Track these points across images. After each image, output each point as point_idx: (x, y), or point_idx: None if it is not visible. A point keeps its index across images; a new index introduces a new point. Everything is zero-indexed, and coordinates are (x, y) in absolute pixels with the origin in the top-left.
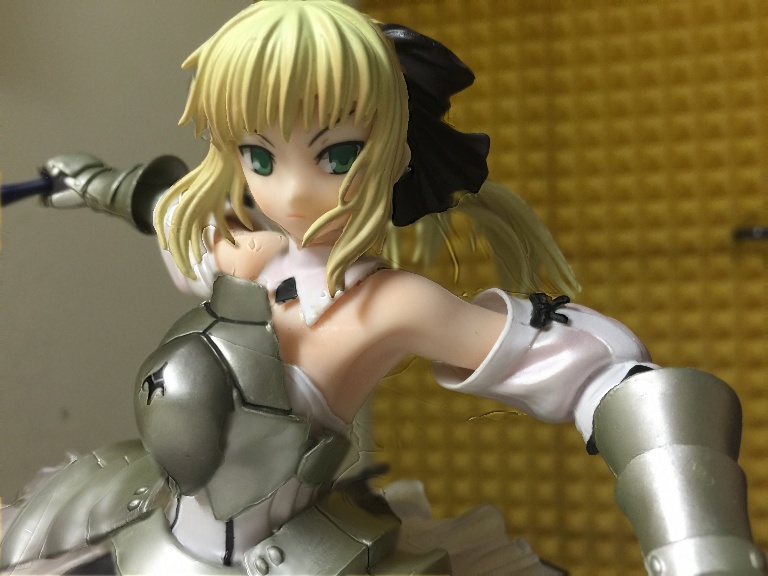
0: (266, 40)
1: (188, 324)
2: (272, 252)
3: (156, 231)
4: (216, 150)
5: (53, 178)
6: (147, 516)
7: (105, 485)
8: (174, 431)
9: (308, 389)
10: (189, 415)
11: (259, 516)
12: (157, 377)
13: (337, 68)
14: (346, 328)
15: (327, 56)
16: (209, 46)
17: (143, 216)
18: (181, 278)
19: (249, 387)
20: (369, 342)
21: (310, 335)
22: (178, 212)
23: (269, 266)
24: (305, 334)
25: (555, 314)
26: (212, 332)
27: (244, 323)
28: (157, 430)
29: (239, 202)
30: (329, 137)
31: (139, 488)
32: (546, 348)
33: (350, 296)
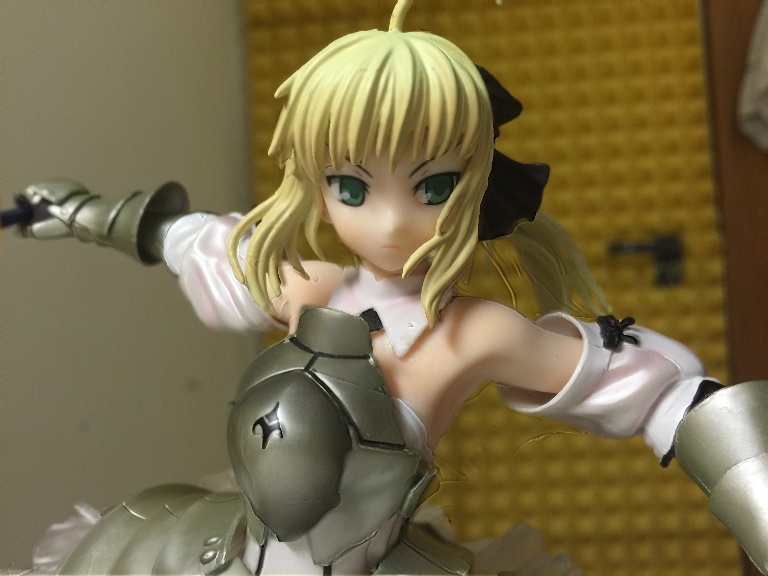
0: (380, 71)
1: (279, 361)
2: (337, 283)
3: (167, 262)
4: (295, 180)
5: (34, 206)
6: (225, 568)
7: (154, 538)
8: (293, 475)
9: (415, 422)
10: (302, 457)
11: (357, 556)
12: (272, 419)
13: (451, 101)
14: (438, 358)
15: (441, 89)
16: (305, 75)
17: (146, 246)
18: (208, 311)
19: (363, 423)
20: (461, 371)
21: (402, 367)
22: (255, 244)
23: (337, 297)
24: (396, 366)
25: (625, 336)
26: (316, 368)
27: (346, 357)
28: (272, 475)
29: (315, 233)
30: (430, 168)
31: (209, 538)
32: (622, 369)
33: (435, 325)
